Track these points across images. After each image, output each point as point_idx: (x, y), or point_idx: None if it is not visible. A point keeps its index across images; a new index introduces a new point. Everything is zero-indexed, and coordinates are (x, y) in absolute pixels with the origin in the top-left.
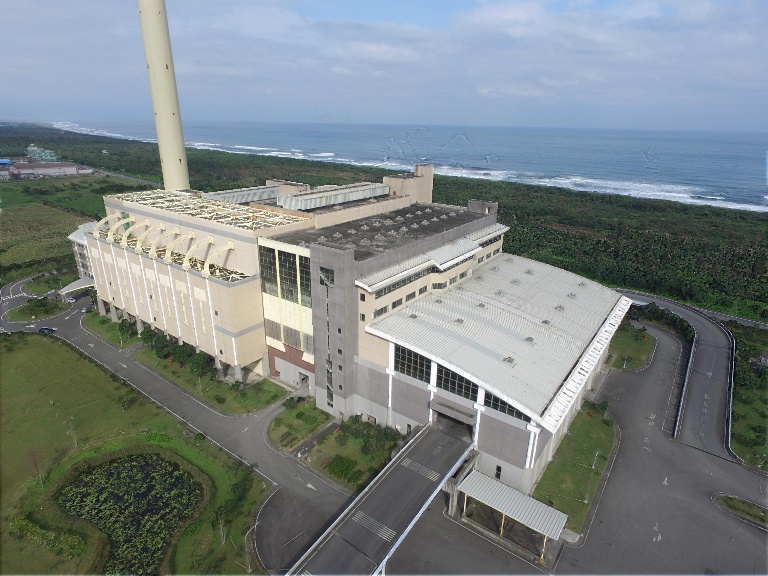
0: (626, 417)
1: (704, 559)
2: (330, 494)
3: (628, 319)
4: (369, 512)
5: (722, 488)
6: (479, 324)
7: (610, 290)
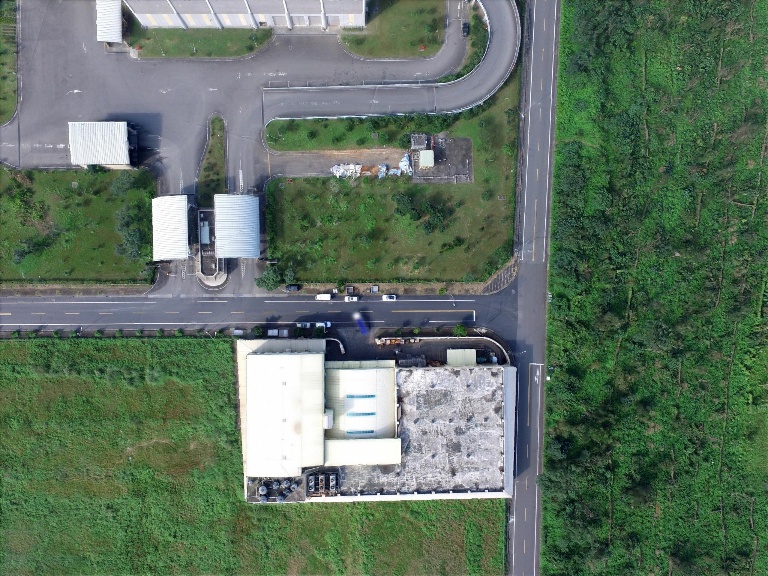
0: (268, 58)
1: (164, 112)
2: None
3: (433, 22)
4: None
5: (229, 117)
6: None
7: None
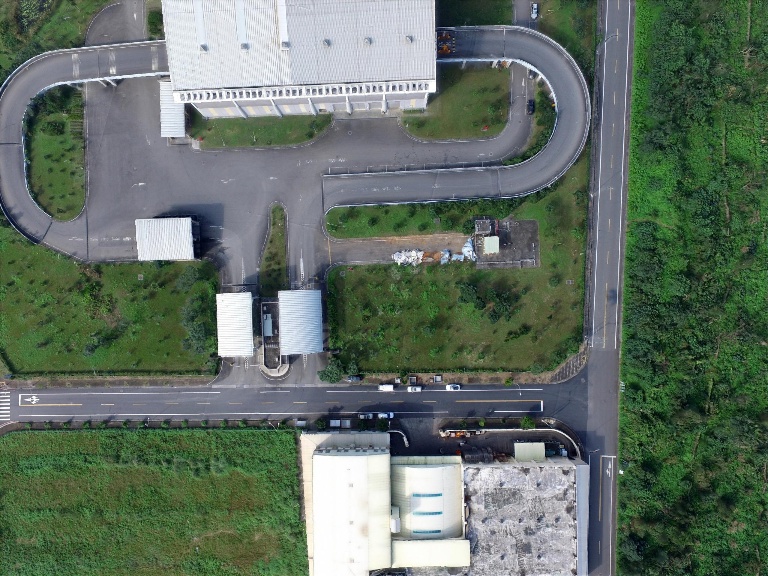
0: (328, 144)
1: (226, 202)
2: (138, 29)
3: (497, 103)
4: (116, 55)
5: (289, 206)
6: (231, 4)
7: (433, 65)
